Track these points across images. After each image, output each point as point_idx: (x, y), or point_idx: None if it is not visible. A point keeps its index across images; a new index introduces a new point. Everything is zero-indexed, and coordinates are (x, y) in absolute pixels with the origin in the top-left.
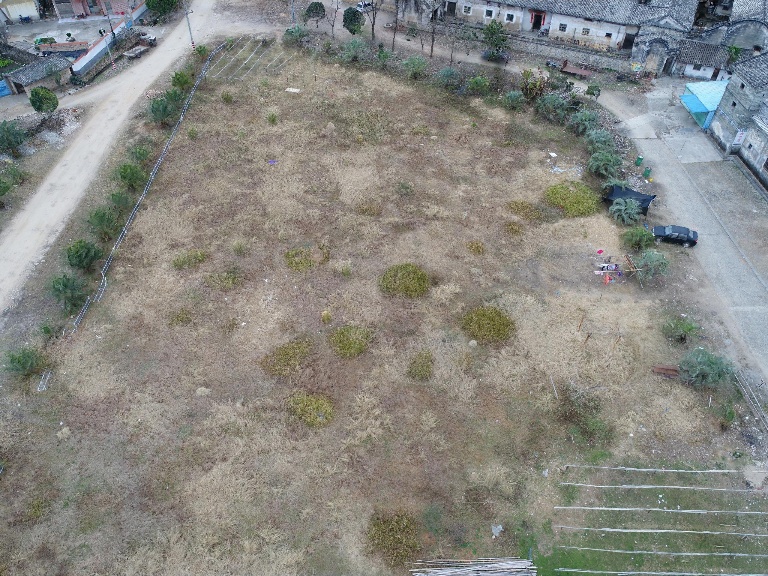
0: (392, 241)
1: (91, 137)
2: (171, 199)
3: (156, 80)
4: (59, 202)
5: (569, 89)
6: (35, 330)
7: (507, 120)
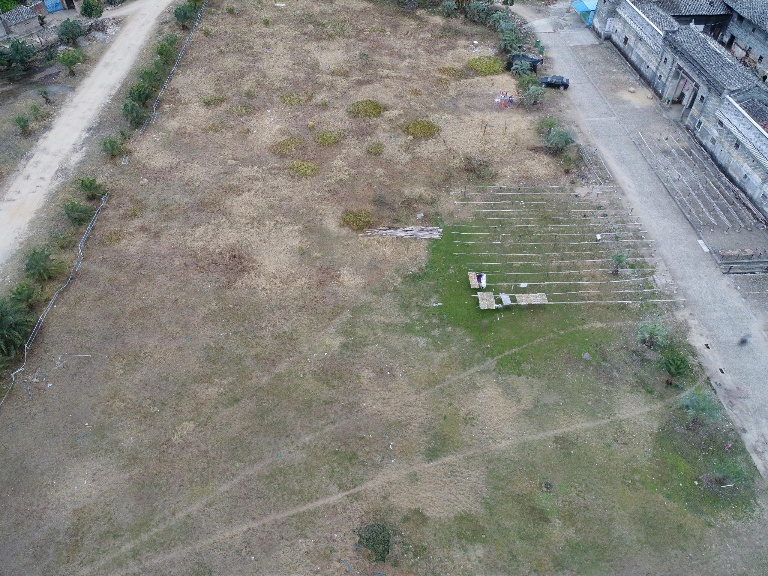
0: (356, 90)
1: (130, 35)
2: (196, 69)
3: (173, 1)
4: (114, 72)
5: (490, 0)
6: (113, 137)
7: (443, 23)
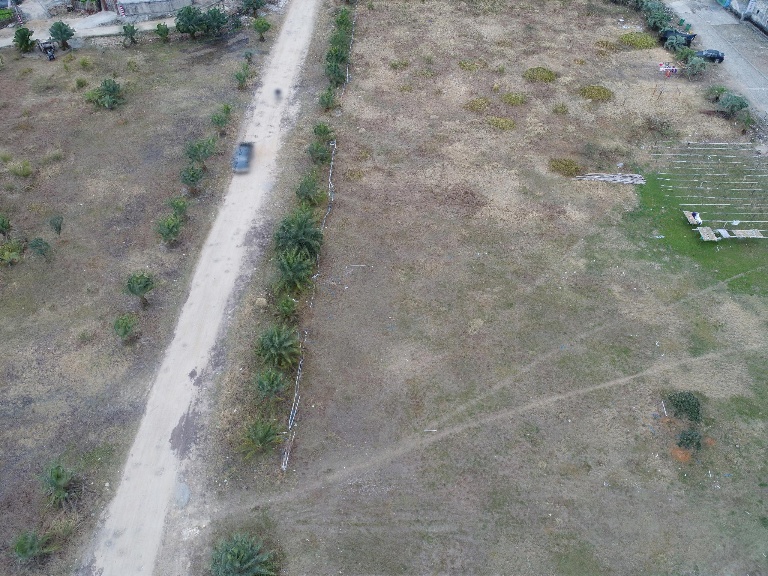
0: (525, 59)
1: (300, 8)
2: (371, 38)
3: None
4: (298, 39)
5: None
6: (319, 93)
7: (585, 2)
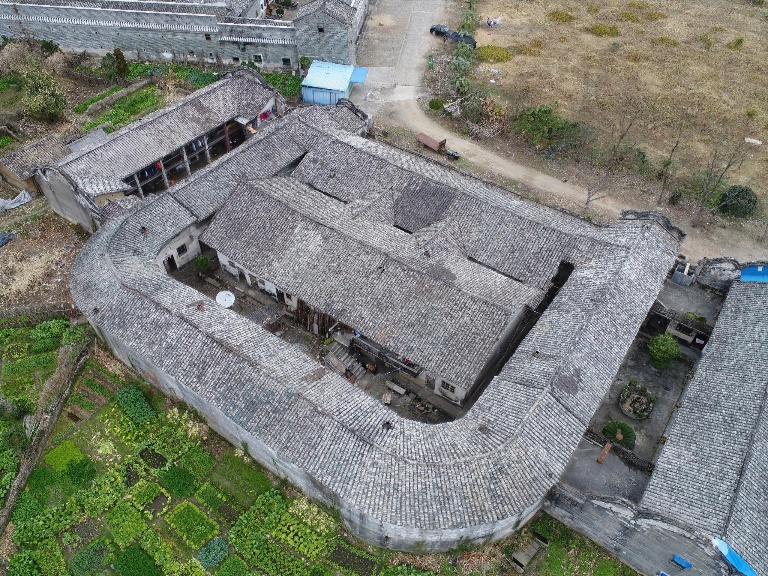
0: None
1: None
2: None
3: None
4: None
5: None
6: None
7: None
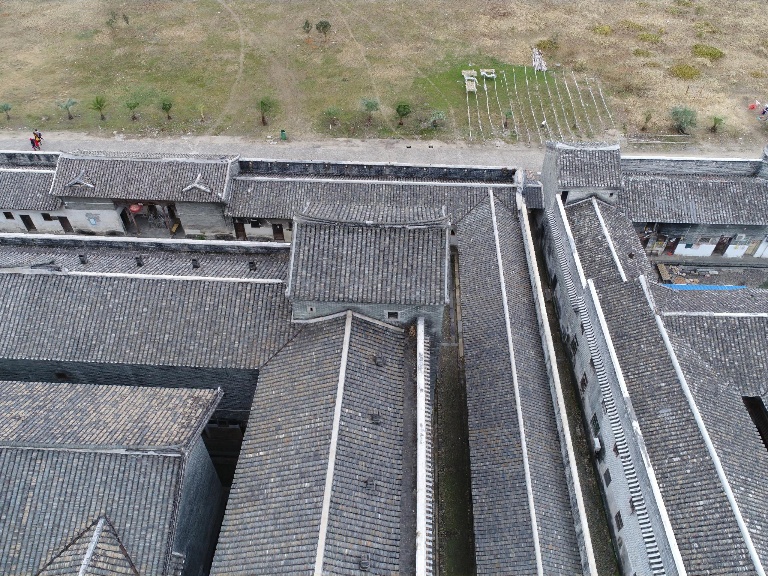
0: (742, 51)
1: None
2: None
3: None
4: None
5: None
6: None
7: None
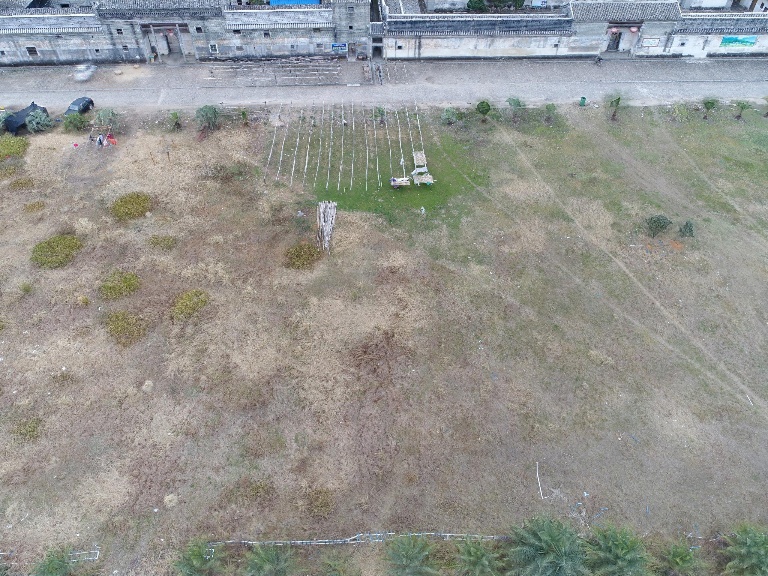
0: None
1: None
2: None
3: None
4: None
5: None
6: None
7: None
